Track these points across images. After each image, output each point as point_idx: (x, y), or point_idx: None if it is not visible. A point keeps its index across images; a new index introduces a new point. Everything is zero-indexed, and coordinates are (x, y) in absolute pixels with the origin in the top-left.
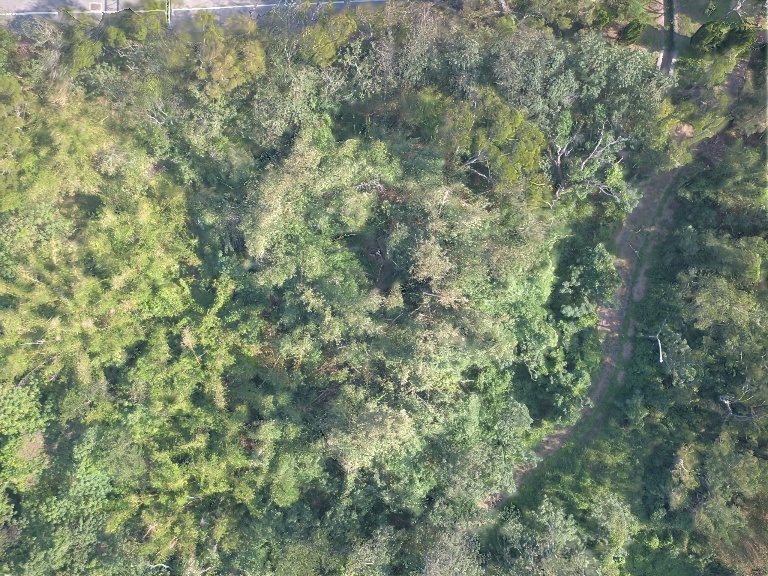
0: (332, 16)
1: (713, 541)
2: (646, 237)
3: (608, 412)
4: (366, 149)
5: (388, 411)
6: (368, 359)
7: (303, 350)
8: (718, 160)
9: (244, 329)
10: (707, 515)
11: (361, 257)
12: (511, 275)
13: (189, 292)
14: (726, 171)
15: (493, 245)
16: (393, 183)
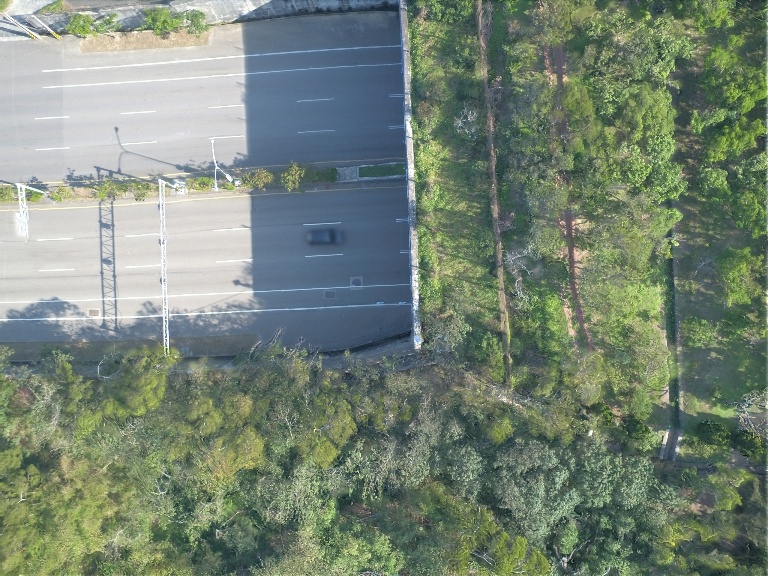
0: (332, 395)
1: None
2: None
3: None
4: (371, 544)
5: None
6: None
7: None
8: (726, 543)
9: None
10: None
11: None
12: None
13: None
14: None
15: None
16: (399, 575)
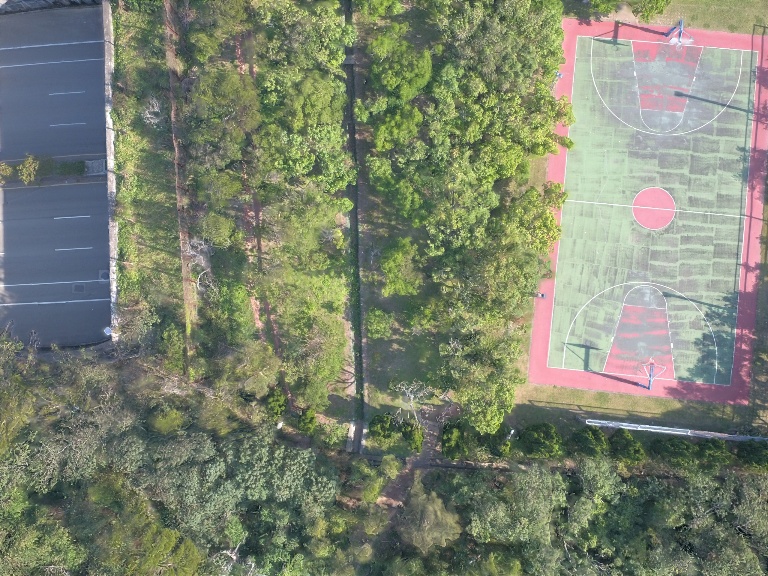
0: (23, 387)
1: None
2: None
3: None
4: (49, 538)
5: None
6: None
7: None
8: (408, 537)
9: None
10: None
11: None
12: None
13: None
14: None
15: None
16: (79, 569)
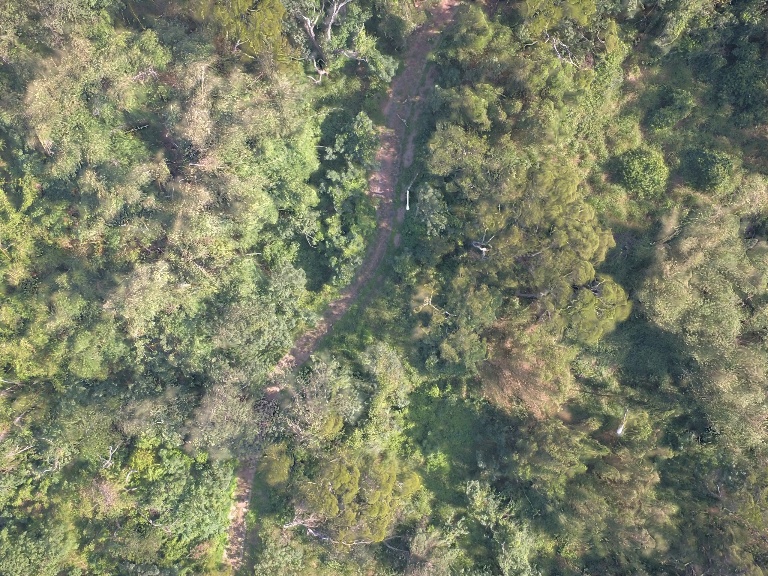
0: None
1: (484, 383)
2: (412, 106)
3: (386, 273)
4: (138, 38)
5: (170, 280)
6: (155, 236)
7: (100, 236)
8: None
9: (47, 222)
10: (451, 346)
11: (152, 146)
12: (267, 140)
13: (5, 197)
14: (461, 29)
15: (250, 114)
16: (166, 69)
